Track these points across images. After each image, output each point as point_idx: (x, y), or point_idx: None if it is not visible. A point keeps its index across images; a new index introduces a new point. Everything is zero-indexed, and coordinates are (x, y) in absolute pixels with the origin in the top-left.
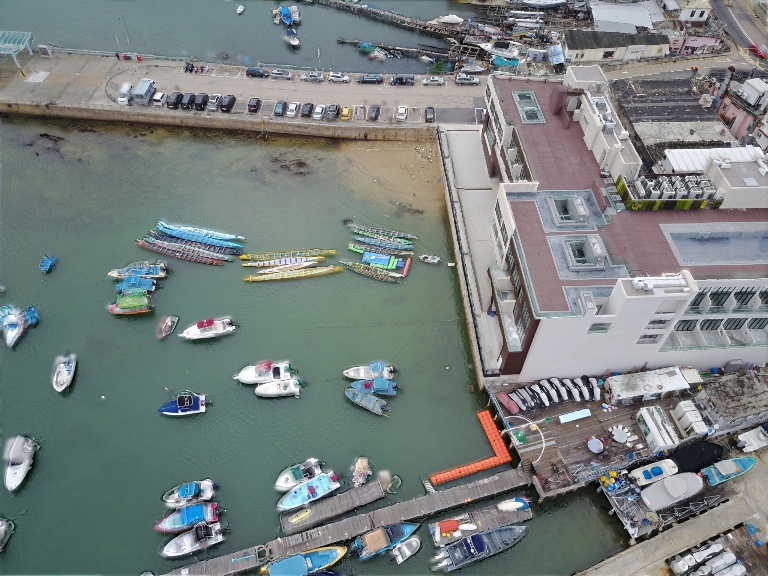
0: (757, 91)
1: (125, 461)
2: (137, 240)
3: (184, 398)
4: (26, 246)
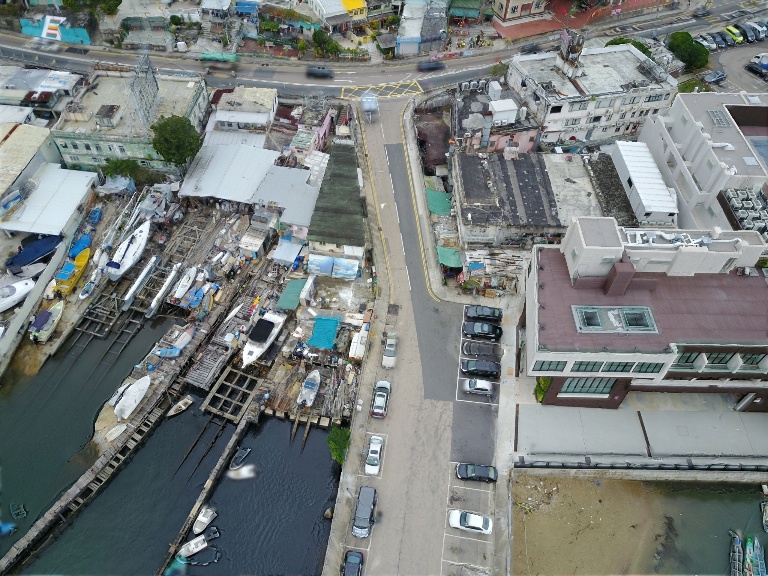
0: (515, 110)
1: None
2: None
3: None
4: None
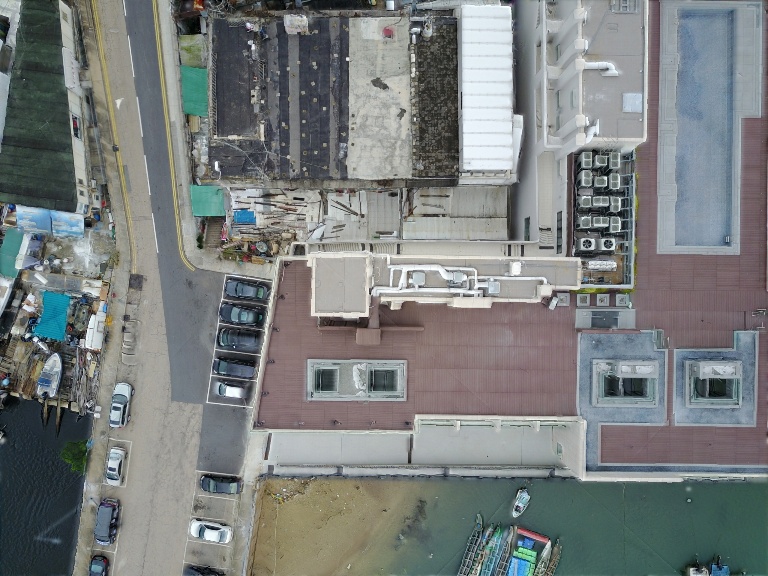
0: None
1: None
2: None
3: None
4: None
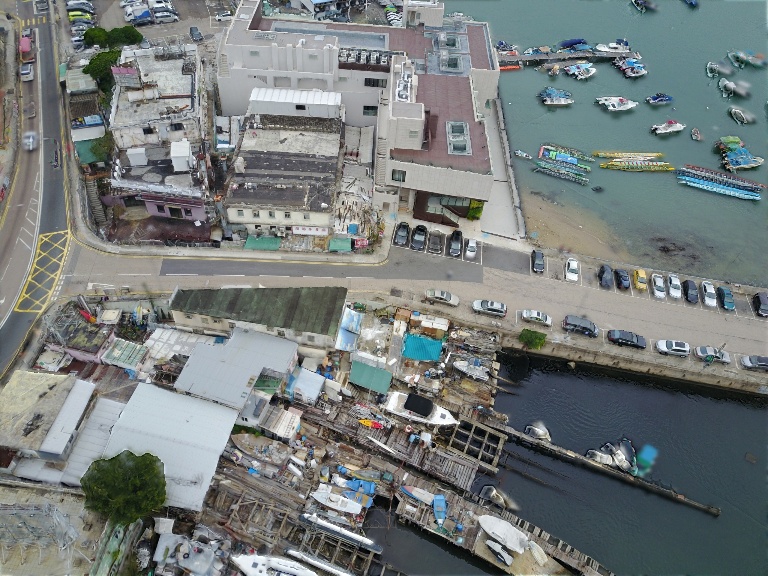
0: None
1: (675, 89)
2: (766, 187)
3: (661, 95)
4: None
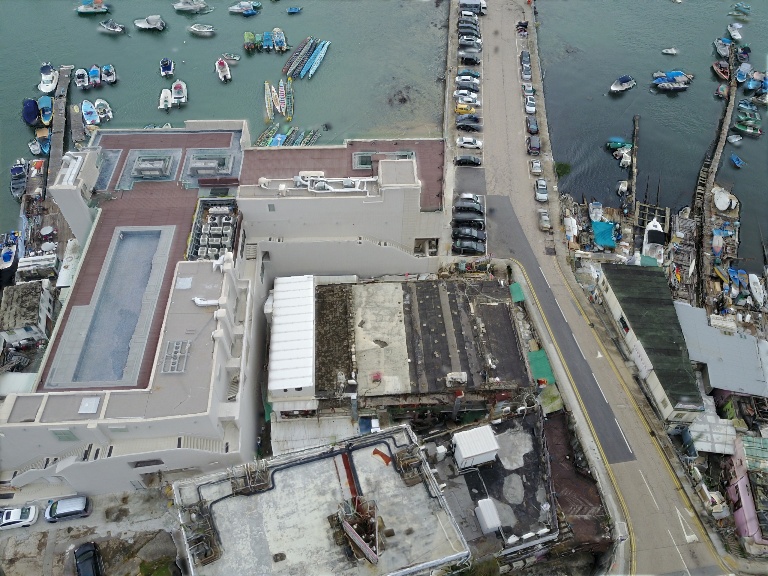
0: None
1: None
2: (311, 36)
3: (167, 62)
4: (312, 2)
